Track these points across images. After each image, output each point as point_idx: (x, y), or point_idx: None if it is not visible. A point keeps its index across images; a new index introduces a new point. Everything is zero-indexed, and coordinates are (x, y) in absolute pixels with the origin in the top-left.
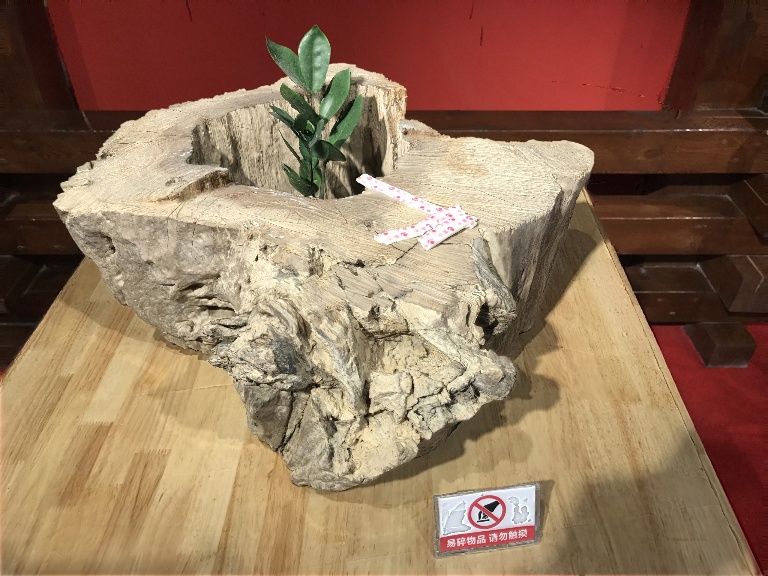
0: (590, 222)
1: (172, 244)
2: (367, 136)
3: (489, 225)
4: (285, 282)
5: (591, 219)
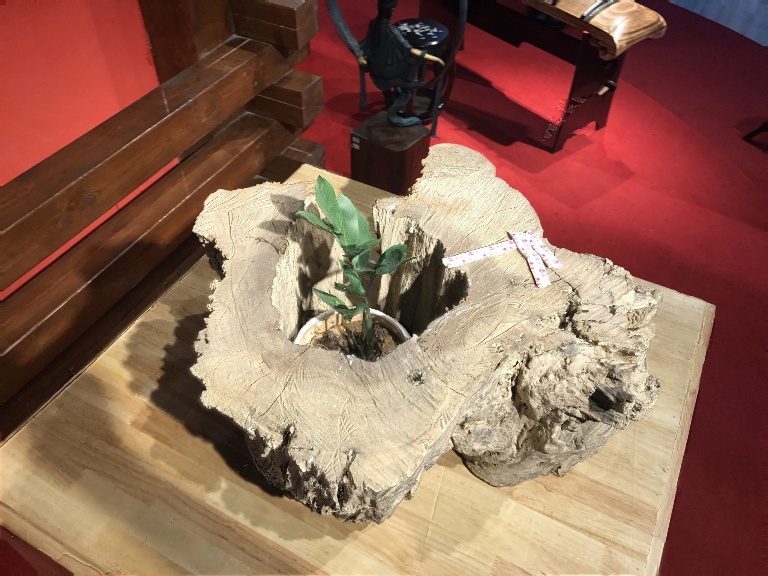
0: (376, 191)
1: (456, 418)
2: (308, 239)
3: (536, 229)
4: (582, 351)
5: (373, 188)
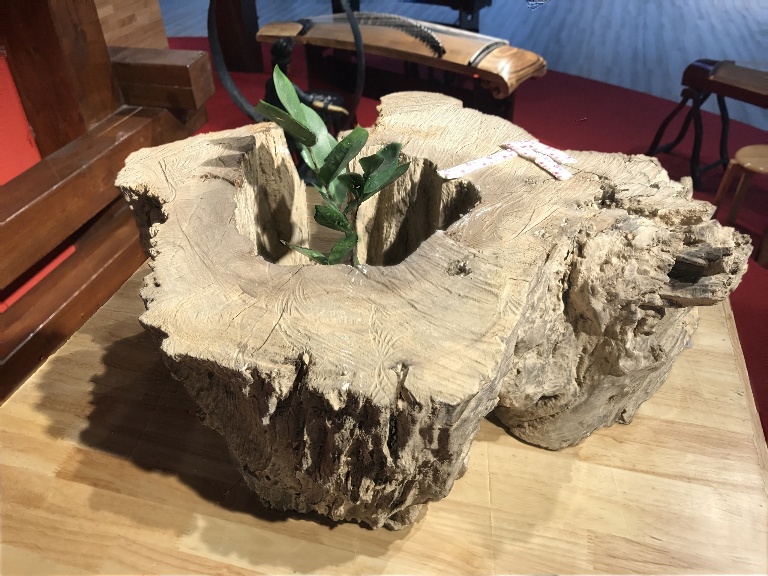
0: None
1: None
2: (262, 196)
3: None
4: (642, 223)
5: None
